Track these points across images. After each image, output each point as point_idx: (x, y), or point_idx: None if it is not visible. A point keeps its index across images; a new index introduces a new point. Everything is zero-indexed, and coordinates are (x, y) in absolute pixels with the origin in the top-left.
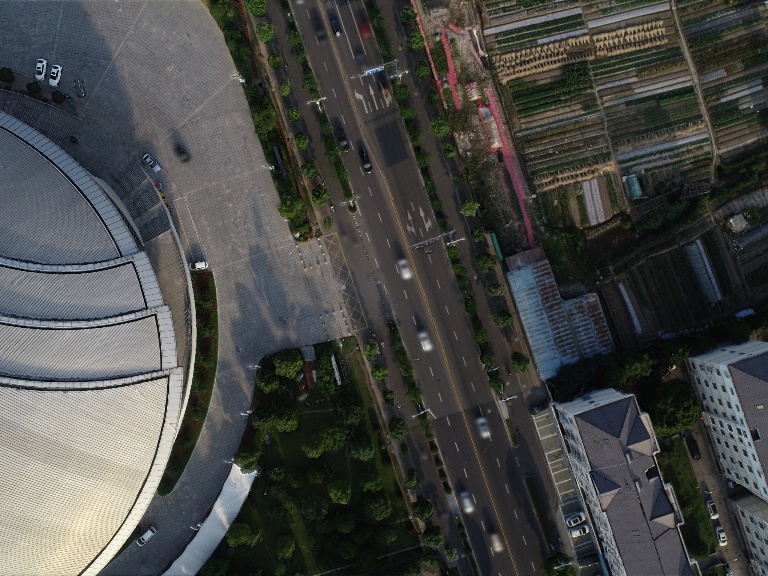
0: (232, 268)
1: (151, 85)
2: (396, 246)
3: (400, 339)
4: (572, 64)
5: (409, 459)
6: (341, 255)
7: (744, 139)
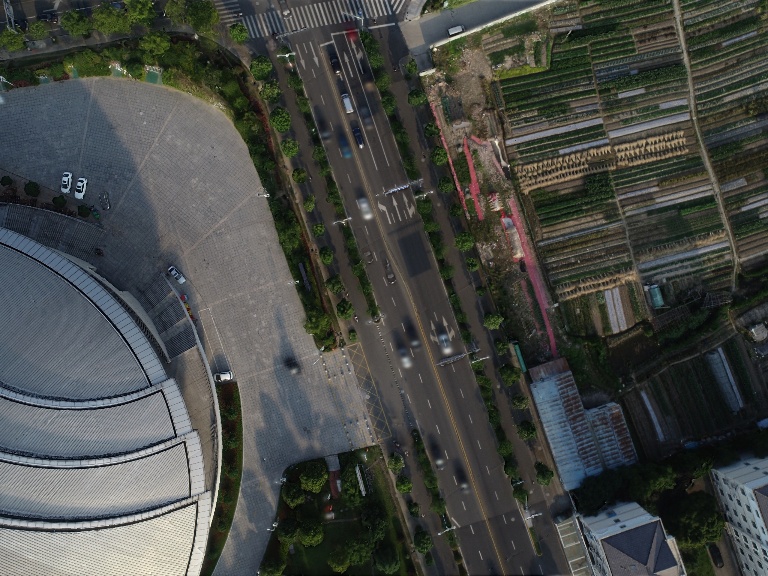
0: (256, 378)
1: (176, 197)
2: (419, 356)
3: (424, 449)
4: (594, 174)
5: (433, 568)
6: (365, 365)
7: (765, 248)
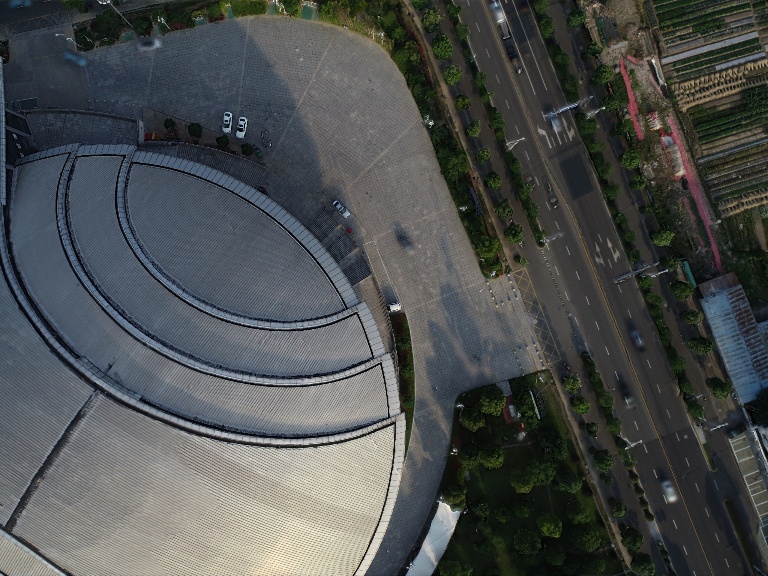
0: (424, 308)
1: (336, 132)
2: (586, 278)
3: (595, 370)
4: (752, 88)
5: (608, 488)
6: (531, 290)
7: None
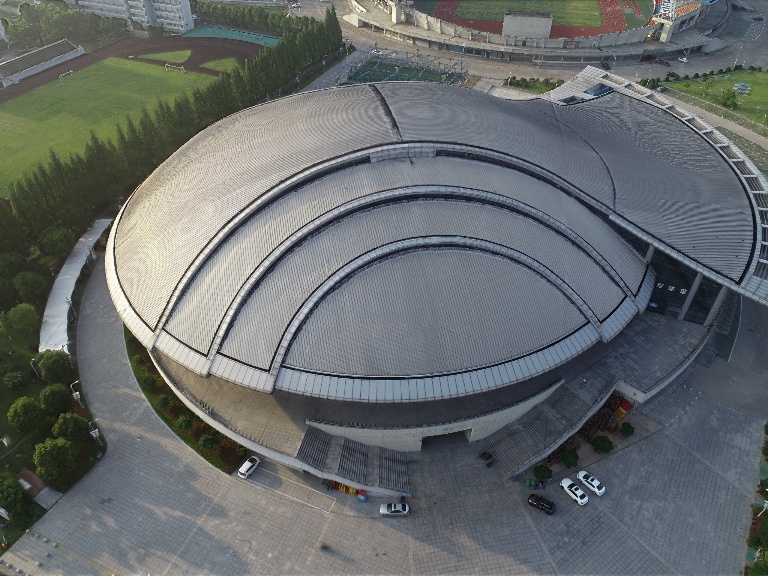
0: (211, 497)
1: None
2: None
3: None
4: None
5: None
6: None
7: None
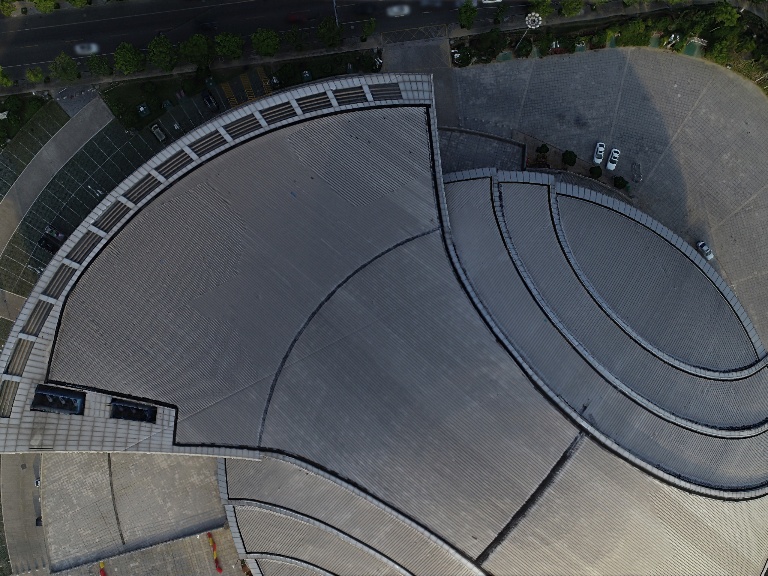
0: None
1: (706, 172)
2: None
3: None
4: None
5: None
6: None
7: None
